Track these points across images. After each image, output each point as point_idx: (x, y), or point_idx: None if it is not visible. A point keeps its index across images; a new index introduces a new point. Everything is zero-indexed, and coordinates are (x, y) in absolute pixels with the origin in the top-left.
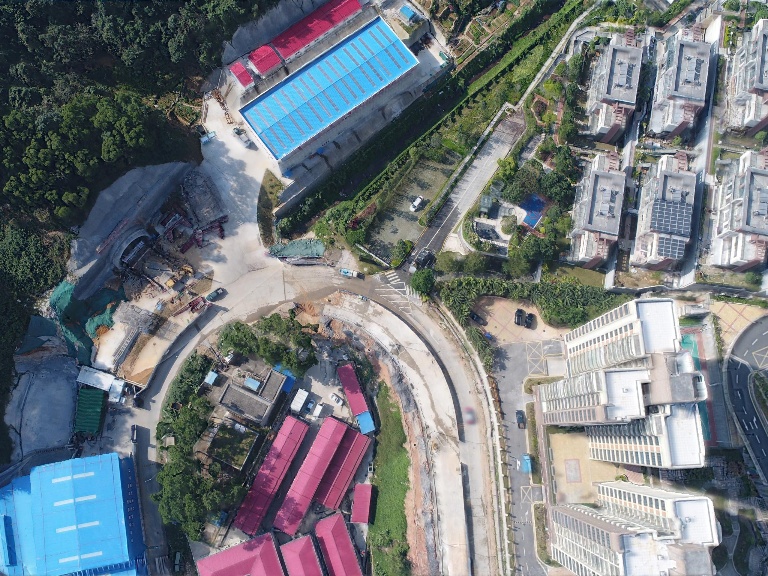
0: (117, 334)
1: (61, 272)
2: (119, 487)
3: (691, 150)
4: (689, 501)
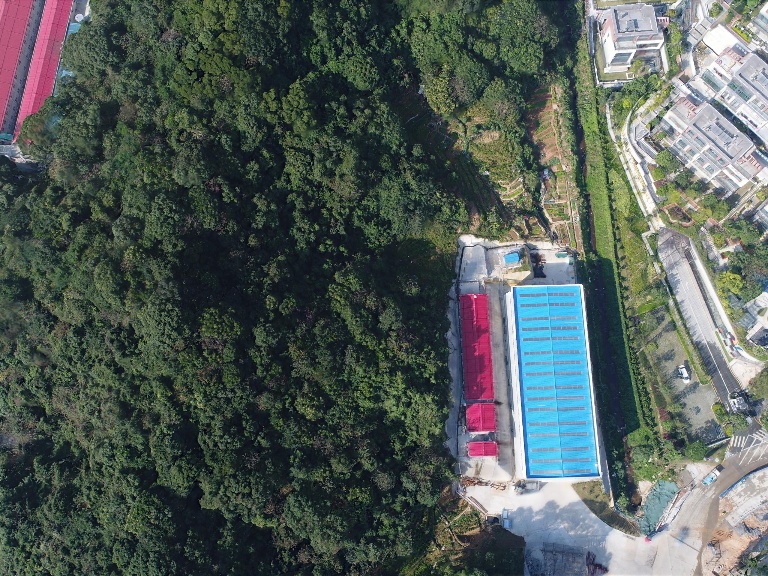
0: None
1: None
2: None
3: None
4: None
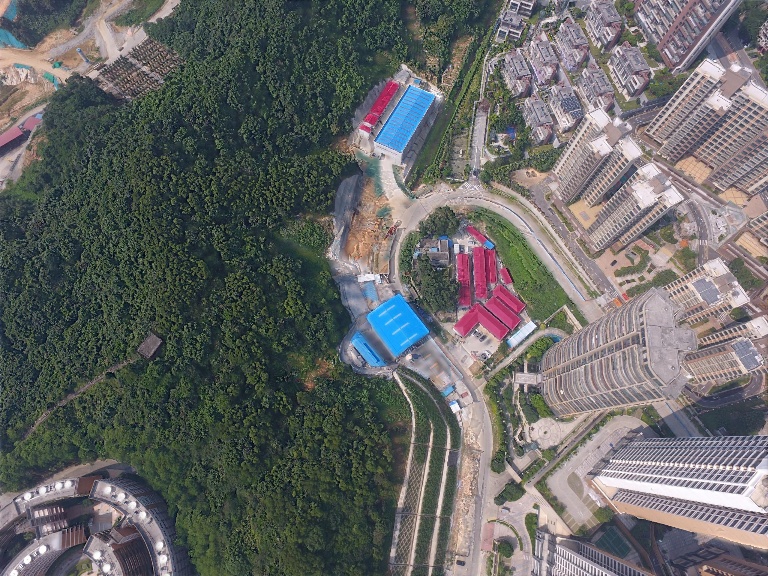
0: (364, 258)
1: (332, 236)
2: (408, 306)
3: None
4: (645, 167)
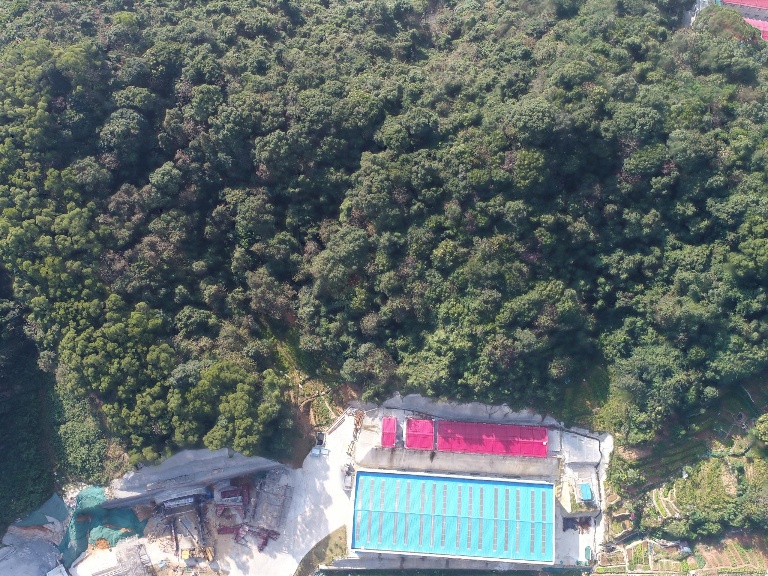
0: (111, 558)
1: (105, 481)
2: None
3: None
4: None
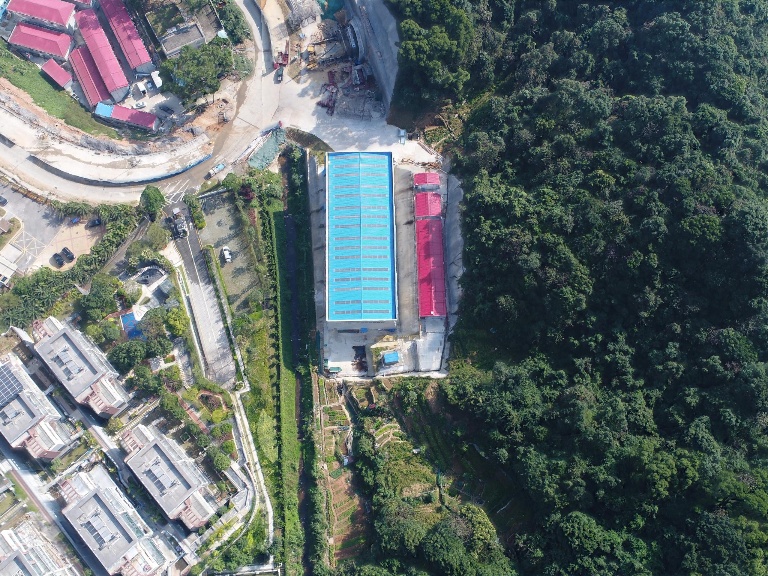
0: None
1: None
2: None
3: (57, 495)
4: None
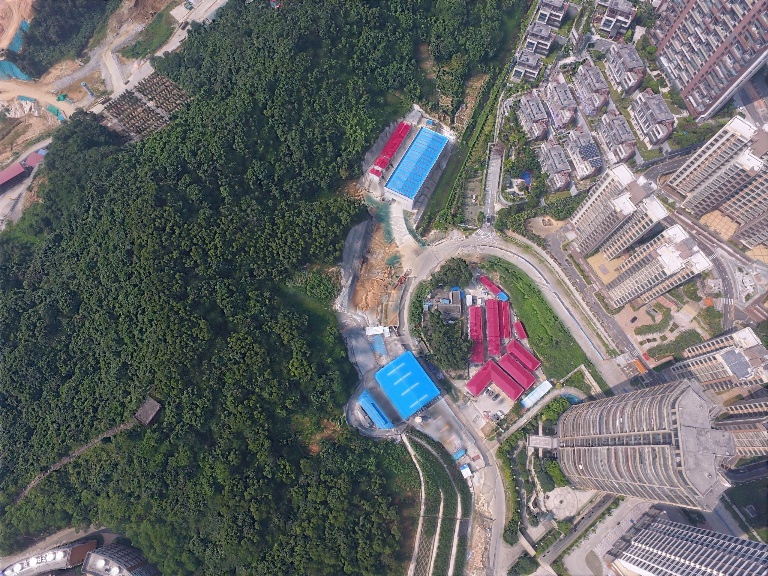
0: (372, 308)
1: (340, 287)
2: (418, 364)
3: None
4: (671, 229)
